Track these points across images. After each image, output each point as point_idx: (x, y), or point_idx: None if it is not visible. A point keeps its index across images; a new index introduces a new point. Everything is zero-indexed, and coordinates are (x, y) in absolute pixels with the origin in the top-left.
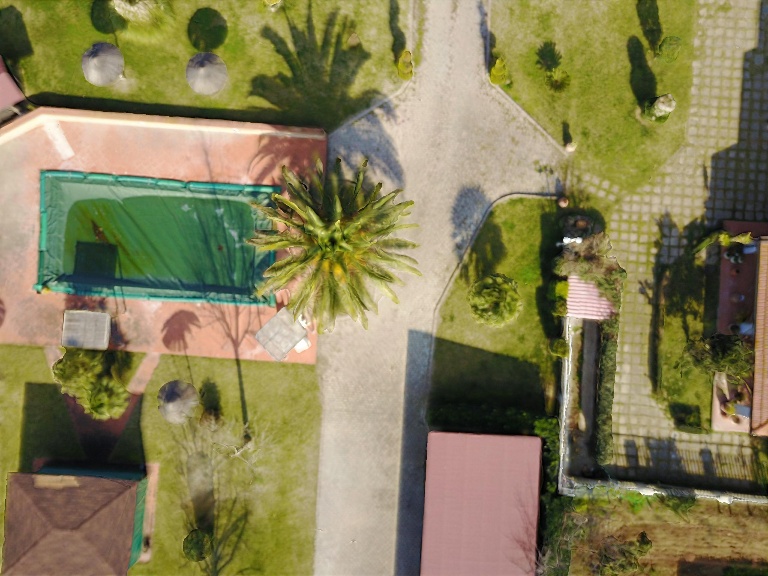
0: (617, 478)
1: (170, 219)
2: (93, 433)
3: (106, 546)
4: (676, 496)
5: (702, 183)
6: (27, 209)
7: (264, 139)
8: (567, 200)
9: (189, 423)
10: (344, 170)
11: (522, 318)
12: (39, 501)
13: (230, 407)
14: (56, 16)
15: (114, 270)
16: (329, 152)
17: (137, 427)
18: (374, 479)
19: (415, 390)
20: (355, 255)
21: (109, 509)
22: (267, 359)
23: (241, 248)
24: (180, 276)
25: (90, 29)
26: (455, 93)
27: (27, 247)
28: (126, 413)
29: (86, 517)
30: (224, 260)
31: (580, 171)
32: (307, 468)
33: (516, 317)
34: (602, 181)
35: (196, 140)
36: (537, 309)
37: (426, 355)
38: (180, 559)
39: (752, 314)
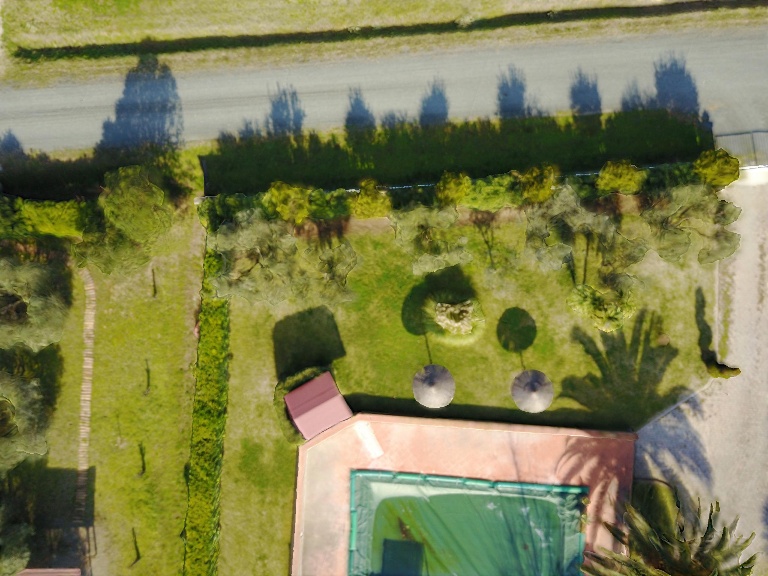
0: None
1: (476, 517)
2: None
3: None
4: None
5: None
6: (338, 508)
7: (572, 438)
8: None
9: None
10: (651, 468)
11: None
12: None
13: None
14: (367, 316)
15: (421, 569)
16: (636, 450)
17: None
18: None
19: None
20: None
21: None
22: None
23: (548, 548)
24: (486, 575)
25: (401, 330)
26: (764, 387)
27: (338, 546)
28: None
29: None
30: (530, 560)
31: None
32: None
33: None
34: None
35: (502, 438)
36: None
37: None
38: None
39: None
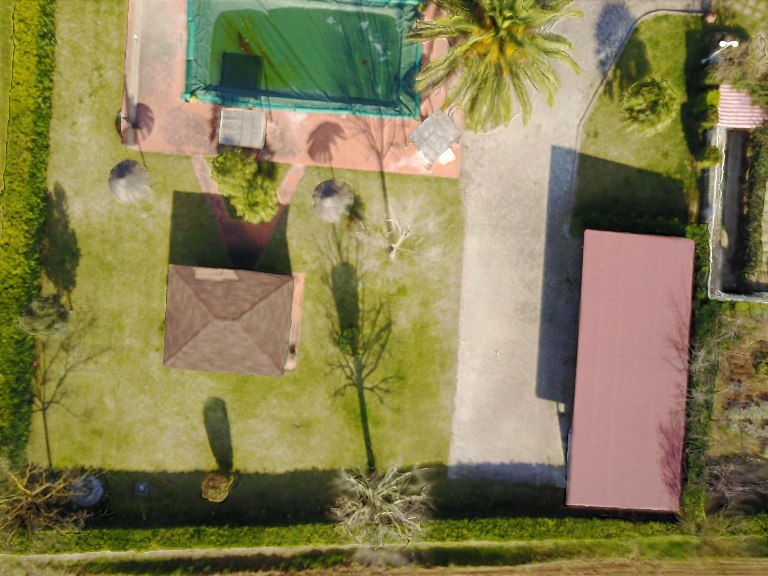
0: None
1: (315, 31)
2: (240, 242)
3: (265, 337)
4: None
5: None
6: (175, 18)
7: None
8: (715, 14)
9: (334, 234)
10: None
11: (666, 134)
12: (200, 292)
13: (375, 219)
14: None
15: (260, 81)
16: None
17: (283, 237)
18: (517, 292)
19: (558, 206)
20: (525, 38)
21: (268, 302)
22: (411, 172)
23: (386, 61)
24: (325, 89)
25: None
26: None
27: (175, 56)
28: (272, 223)
29: (246, 308)
30: (369, 73)
31: None
32: (450, 280)
33: (669, 123)
34: None
35: None
36: (682, 125)
37: (569, 171)
38: (326, 366)
39: None
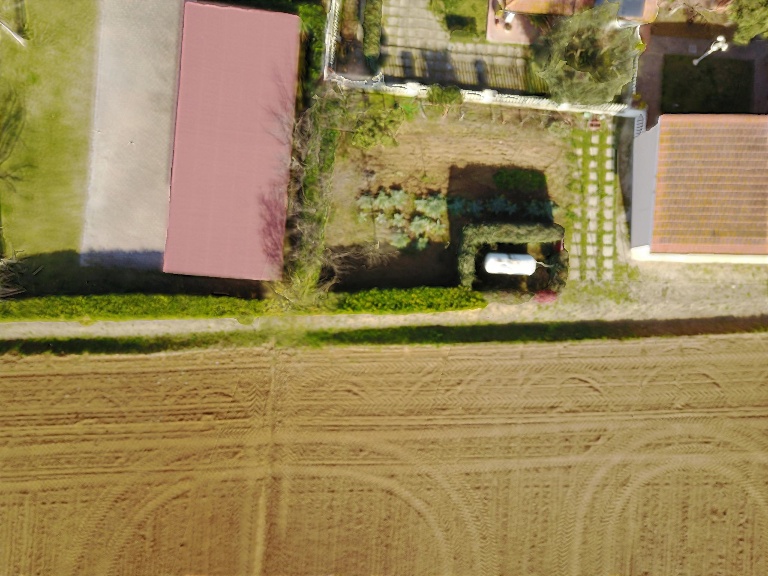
0: None
1: None
2: None
3: None
4: (439, 86)
5: None
6: None
7: None
8: None
9: None
10: None
11: None
12: None
13: None
14: None
15: None
16: None
17: None
18: (153, 84)
19: None
20: None
21: None
22: None
23: None
24: None
25: None
26: None
27: None
28: None
29: None
30: None
31: None
32: (86, 72)
33: None
34: None
35: None
36: None
37: None
38: None
39: None
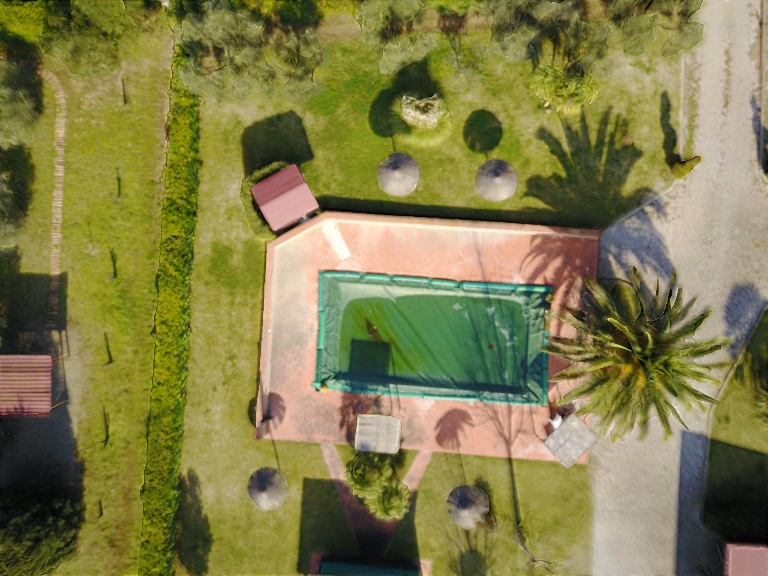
0: None
1: (442, 317)
2: (369, 529)
3: None
4: None
5: None
6: (306, 308)
7: (536, 239)
8: None
9: None
10: (615, 269)
11: None
12: None
13: (504, 506)
14: (334, 120)
15: (388, 368)
16: (600, 251)
17: (412, 524)
18: None
19: (690, 493)
20: None
21: None
22: (539, 458)
23: (512, 347)
24: (452, 374)
25: (368, 133)
26: (727, 190)
27: (306, 345)
28: None
29: None
30: (495, 358)
31: None
32: (581, 569)
33: None
34: None
35: (468, 240)
36: None
37: (700, 457)
38: None
39: None
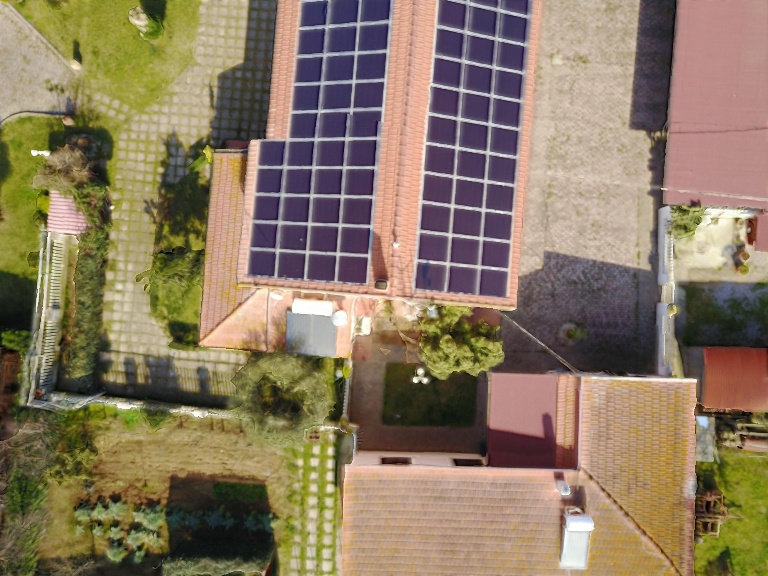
0: (113, 395)
1: None
2: None
3: None
4: (145, 409)
5: (208, 103)
6: None
7: None
8: (68, 118)
9: None
10: None
11: (24, 235)
12: None
13: None
14: None
15: None
16: None
17: None
18: None
19: None
20: None
21: None
22: None
23: None
24: None
25: None
26: None
27: None
28: None
29: None
30: None
31: (91, 90)
32: None
33: None
34: (112, 100)
35: None
36: None
37: None
38: None
39: (206, 227)
